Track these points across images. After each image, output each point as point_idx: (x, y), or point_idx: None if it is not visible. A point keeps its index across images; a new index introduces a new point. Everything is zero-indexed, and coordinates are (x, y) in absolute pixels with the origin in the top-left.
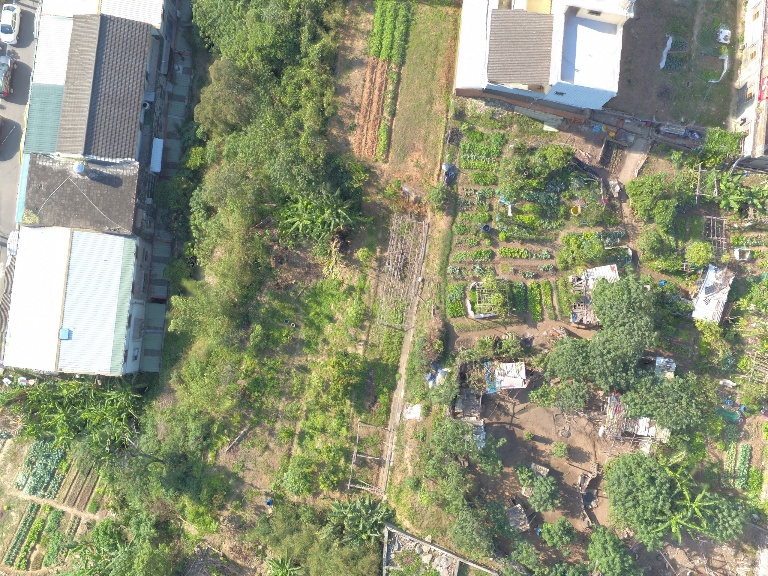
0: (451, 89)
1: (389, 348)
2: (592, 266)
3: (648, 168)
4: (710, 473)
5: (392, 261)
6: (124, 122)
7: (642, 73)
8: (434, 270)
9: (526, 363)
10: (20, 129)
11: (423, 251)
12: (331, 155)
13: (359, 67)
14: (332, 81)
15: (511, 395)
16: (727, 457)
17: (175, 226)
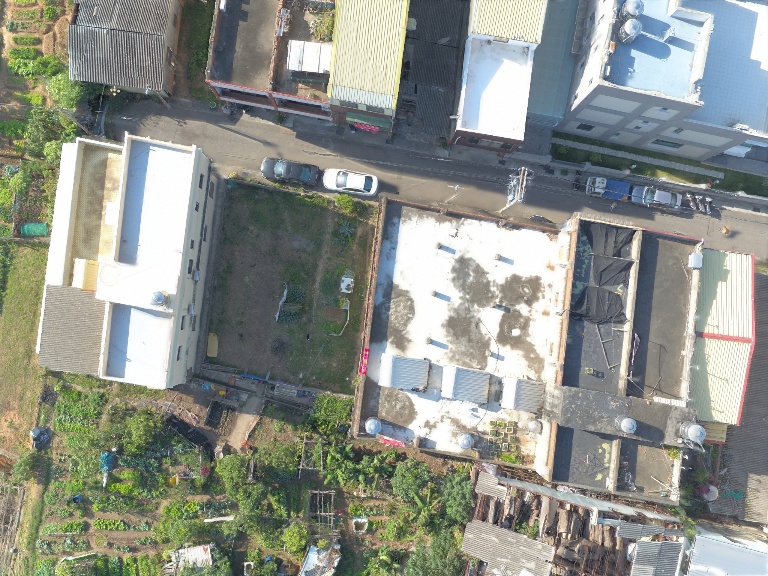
0: None
1: None
2: (195, 538)
3: (261, 430)
4: None
5: None
6: None
7: (256, 326)
8: (23, 543)
9: None
10: None
11: (17, 518)
12: None
13: None
14: None
15: None
16: None
17: None
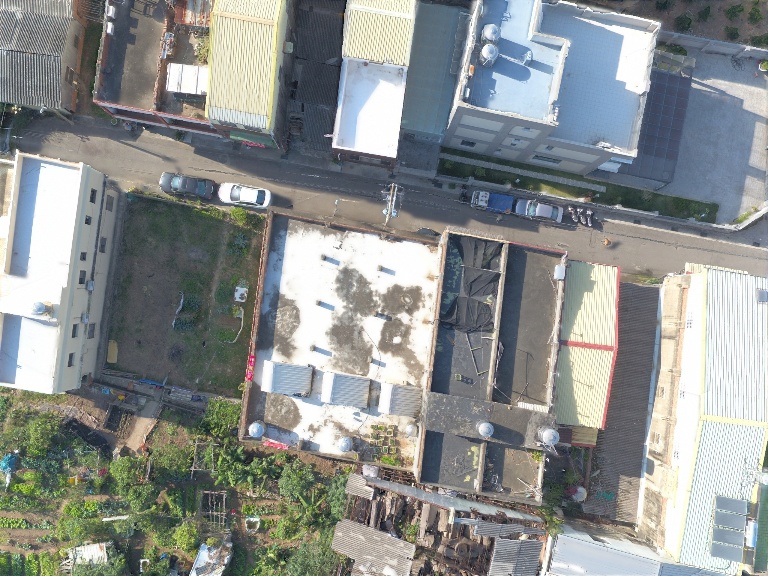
0: None
1: None
2: (95, 537)
3: (158, 433)
4: None
5: None
6: None
7: (154, 333)
8: None
9: None
10: None
11: None
12: None
13: None
14: None
15: None
16: None
17: None
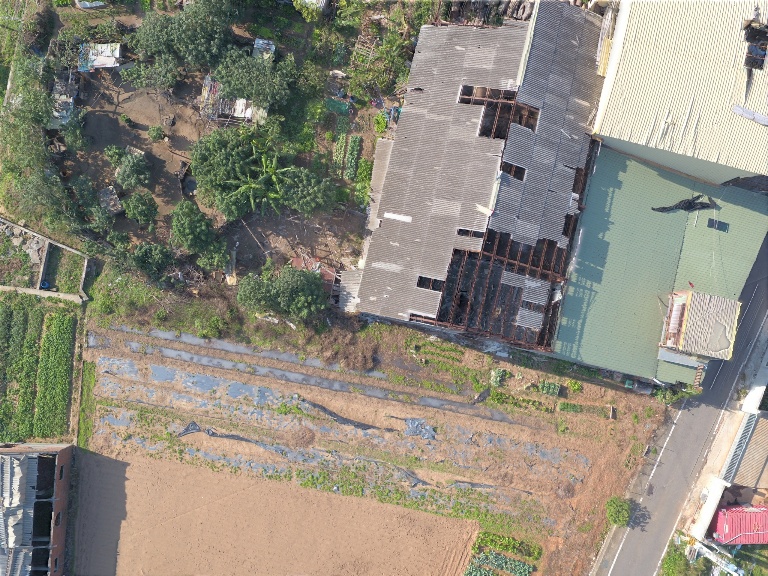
0: None
1: (10, 51)
2: None
3: None
4: (317, 163)
5: None
6: None
7: None
8: None
9: (122, 44)
10: None
11: None
12: None
13: None
14: None
15: (115, 84)
16: (336, 148)
17: None
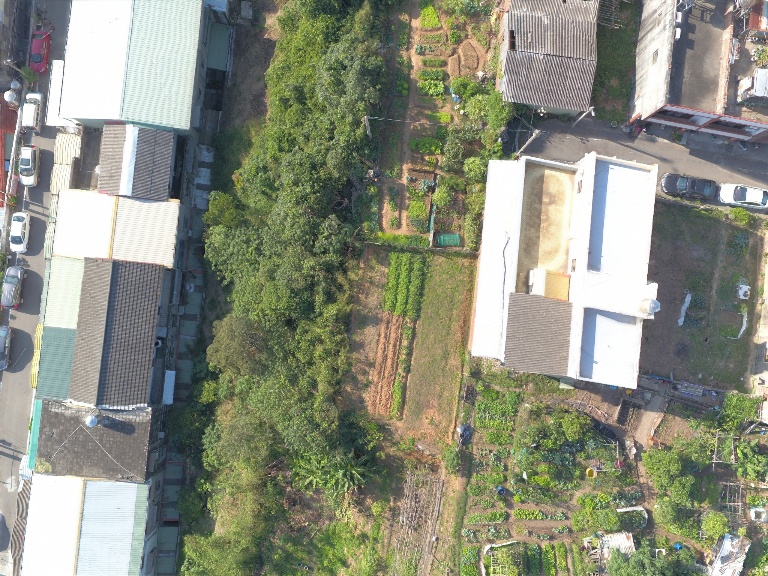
0: (466, 343)
1: None
2: None
3: (665, 426)
4: None
5: (406, 519)
6: (136, 368)
7: (660, 330)
8: (448, 531)
9: None
10: (31, 340)
11: (437, 509)
12: (345, 413)
13: (374, 322)
14: (347, 342)
15: None
16: None
17: (187, 460)
